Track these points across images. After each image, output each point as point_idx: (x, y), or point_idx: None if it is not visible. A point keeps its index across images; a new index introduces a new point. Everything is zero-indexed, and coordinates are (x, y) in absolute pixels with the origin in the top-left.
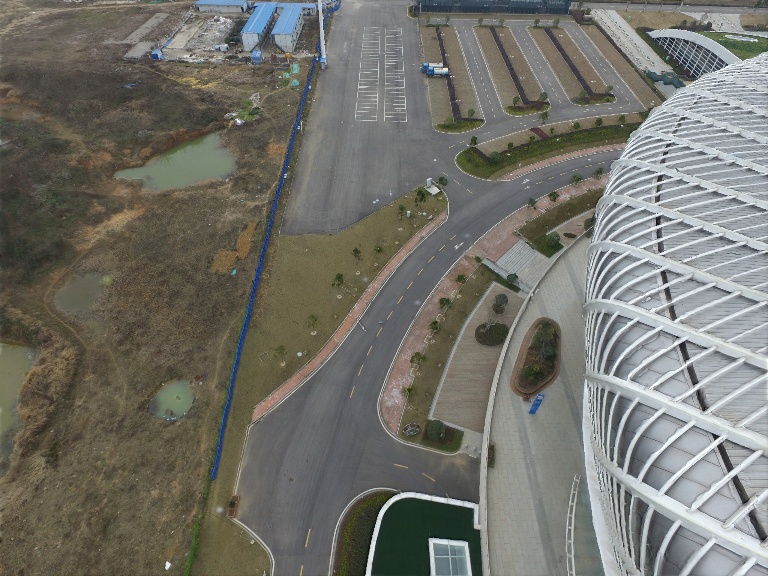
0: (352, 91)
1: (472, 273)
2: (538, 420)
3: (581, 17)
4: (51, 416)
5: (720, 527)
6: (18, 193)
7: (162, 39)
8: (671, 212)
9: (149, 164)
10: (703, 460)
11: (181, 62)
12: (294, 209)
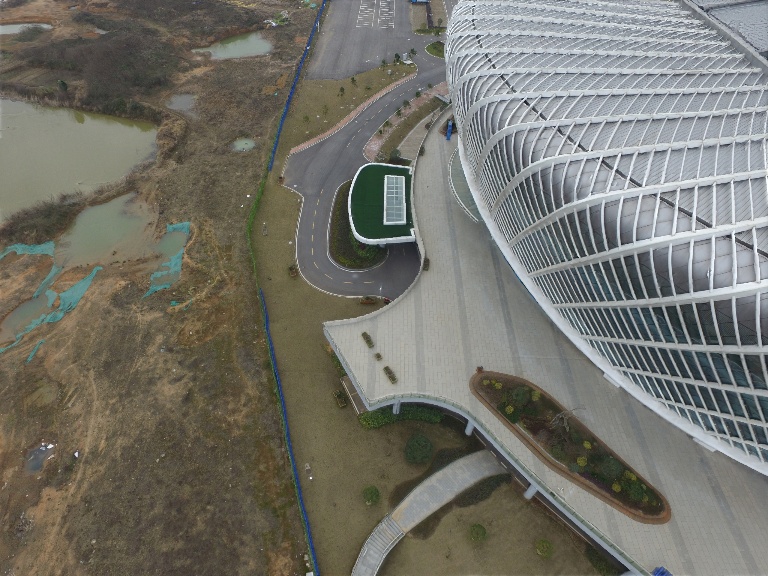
0: (355, 11)
1: (428, 100)
2: (451, 142)
3: None
4: (176, 145)
5: None
6: (132, 53)
7: None
8: None
9: (213, 46)
10: None
11: None
12: (313, 68)
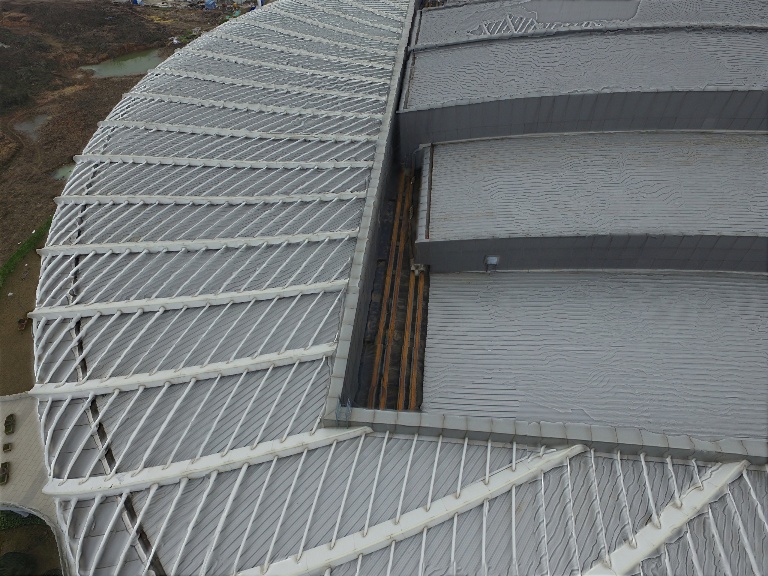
0: None
1: None
2: None
3: None
4: None
5: None
6: (8, 70)
7: None
8: None
9: (103, 63)
10: None
11: (154, 7)
12: None
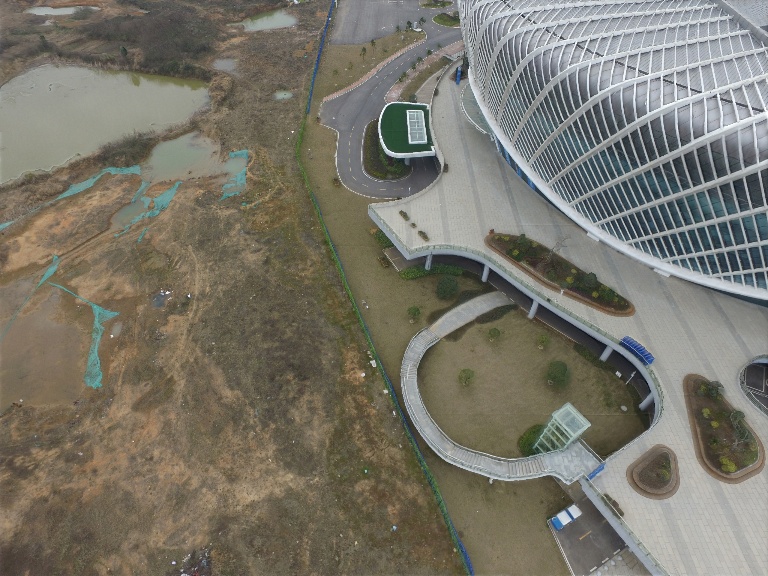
0: None
1: (437, 59)
2: (460, 86)
3: None
4: (226, 96)
5: None
6: None
7: None
8: None
9: (245, 21)
10: None
11: None
12: (336, 36)
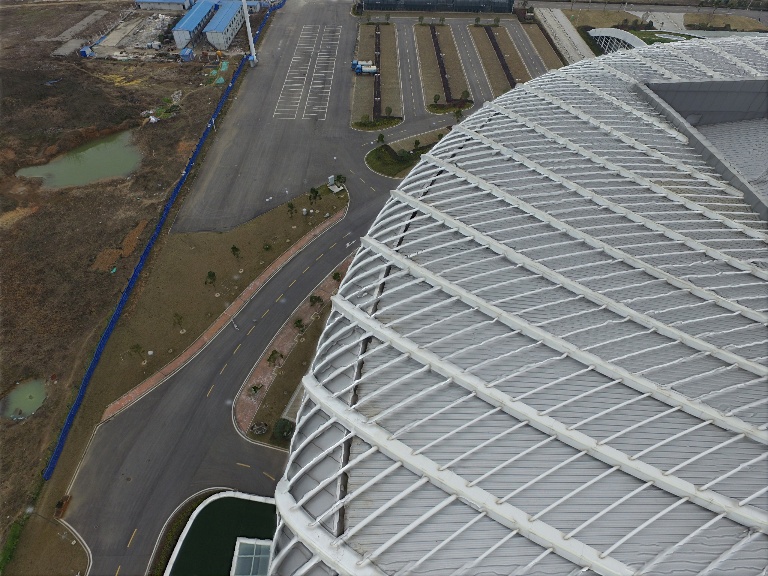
0: (276, 89)
1: None
2: None
3: (524, 16)
4: None
5: (306, 525)
6: None
7: (95, 36)
8: (424, 207)
9: (54, 162)
10: (329, 457)
11: (109, 59)
12: (190, 207)
